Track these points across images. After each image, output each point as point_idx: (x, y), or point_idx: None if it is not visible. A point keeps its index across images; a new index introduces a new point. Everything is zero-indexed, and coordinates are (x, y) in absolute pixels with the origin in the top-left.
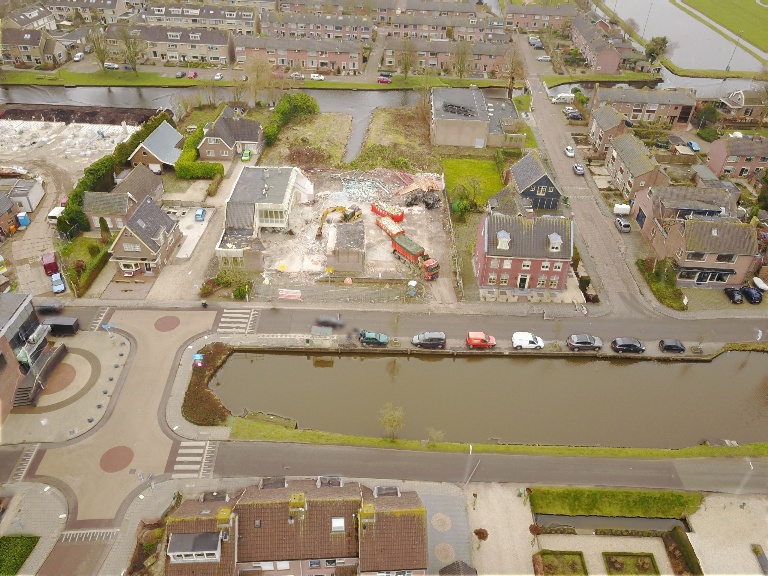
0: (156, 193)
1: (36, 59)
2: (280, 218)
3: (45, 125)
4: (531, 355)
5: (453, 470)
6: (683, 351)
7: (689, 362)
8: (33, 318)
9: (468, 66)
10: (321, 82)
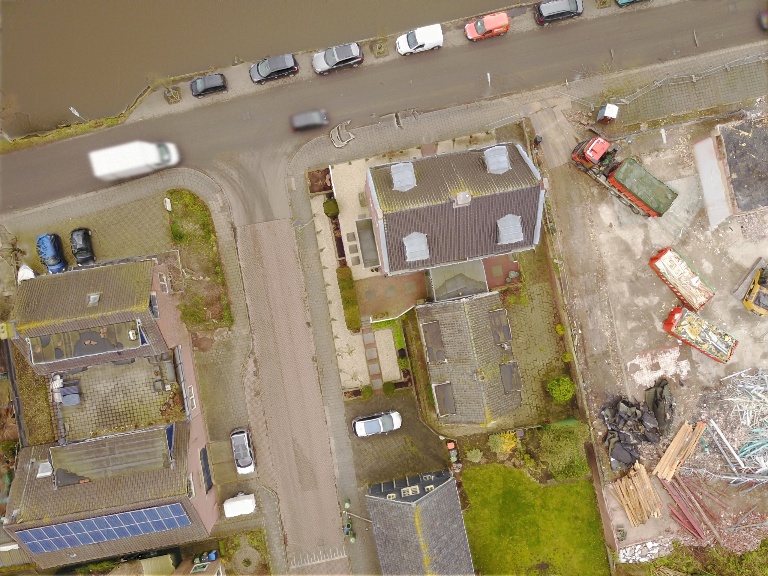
0: None
1: None
2: None
3: None
4: None
5: None
6: None
7: None
8: None
9: None
10: None
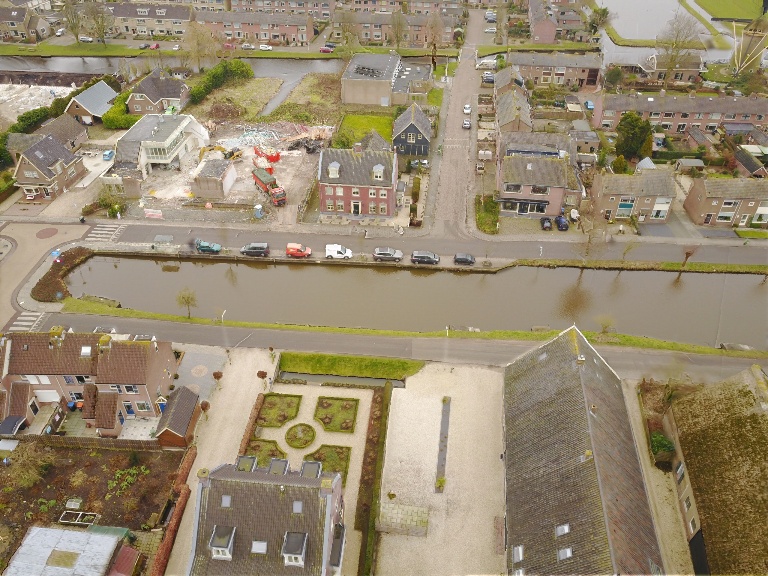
0: (77, 138)
1: (22, 34)
2: (164, 155)
3: (9, 86)
4: (340, 264)
5: (227, 338)
6: (473, 263)
7: (478, 273)
8: None
9: (404, 36)
10: (268, 52)
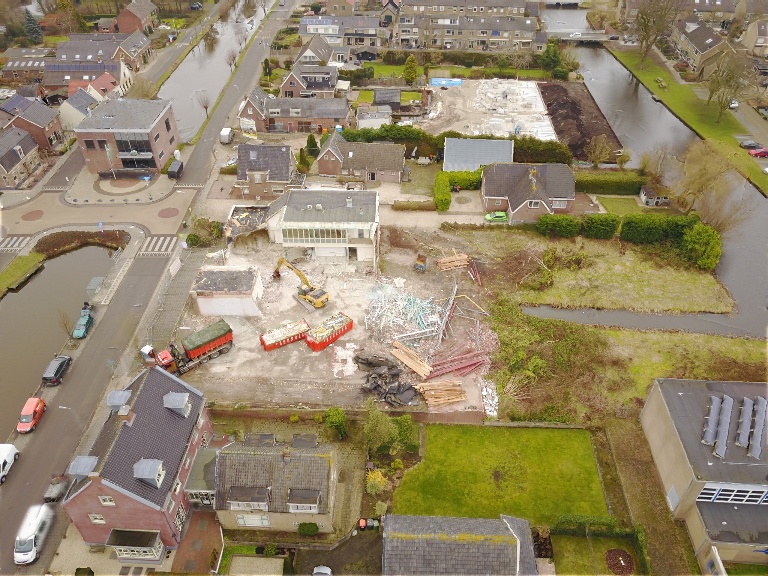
0: None
1: None
2: None
3: None
4: None
5: None
6: None
7: None
8: (148, 145)
9: None
10: None
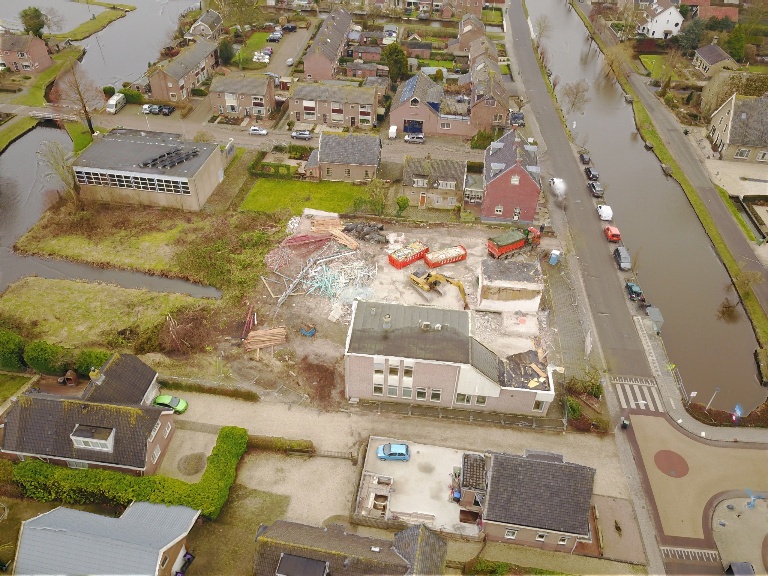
0: None
1: None
2: None
3: None
4: None
5: (756, 268)
6: None
7: None
8: None
9: None
10: None
